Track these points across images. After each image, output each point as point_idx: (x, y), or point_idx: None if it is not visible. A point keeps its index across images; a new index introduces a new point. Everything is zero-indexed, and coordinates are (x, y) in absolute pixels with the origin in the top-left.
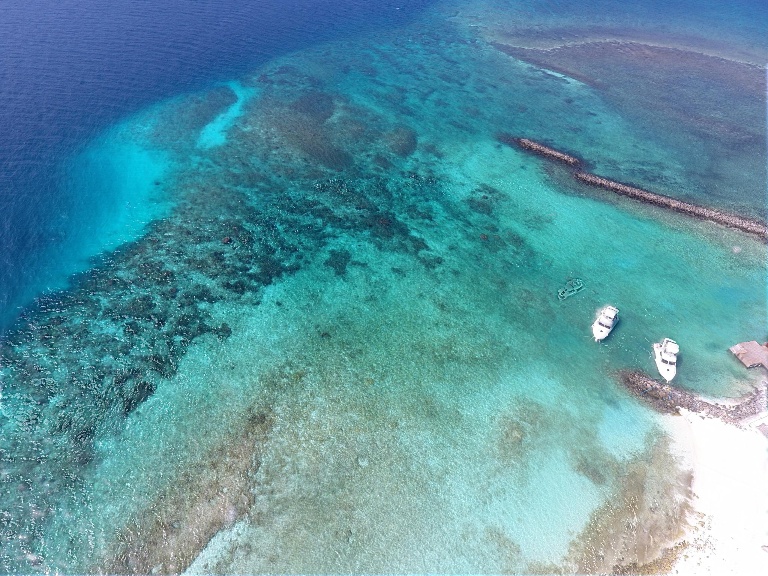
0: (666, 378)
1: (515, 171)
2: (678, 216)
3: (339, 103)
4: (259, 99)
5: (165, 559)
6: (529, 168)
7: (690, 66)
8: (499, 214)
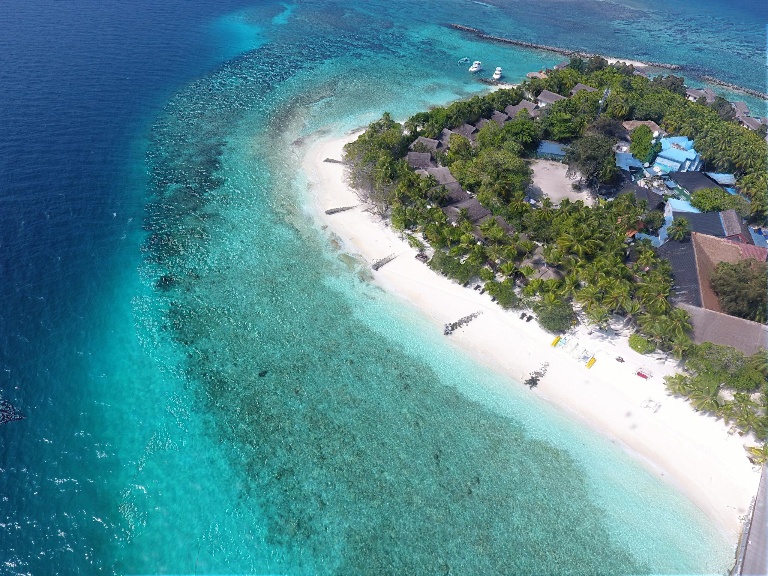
0: (495, 77)
1: (446, 34)
2: (525, 48)
3: (348, 11)
4: (300, 8)
5: (309, 100)
6: (454, 34)
7: (566, 1)
8: (435, 46)
